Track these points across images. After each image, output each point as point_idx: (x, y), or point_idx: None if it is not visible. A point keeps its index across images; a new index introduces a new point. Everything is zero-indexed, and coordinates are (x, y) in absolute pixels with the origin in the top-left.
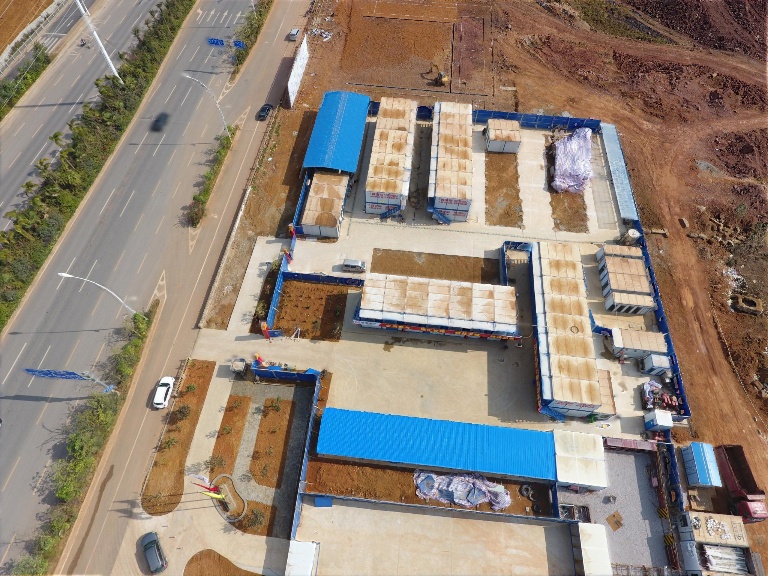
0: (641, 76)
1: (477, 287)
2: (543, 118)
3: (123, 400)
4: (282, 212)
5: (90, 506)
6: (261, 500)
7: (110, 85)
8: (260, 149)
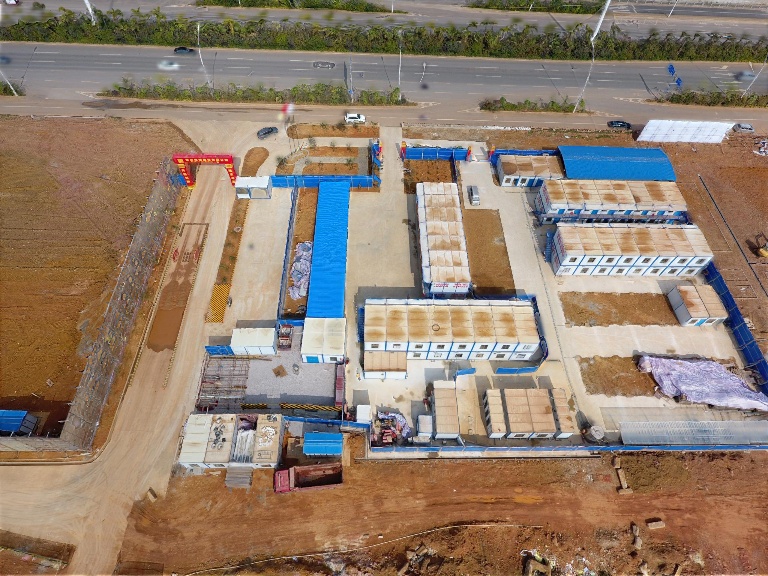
0: None
1: (462, 254)
2: (754, 347)
3: (349, 105)
4: None
5: (291, 107)
6: (295, 170)
7: (583, 32)
8: None
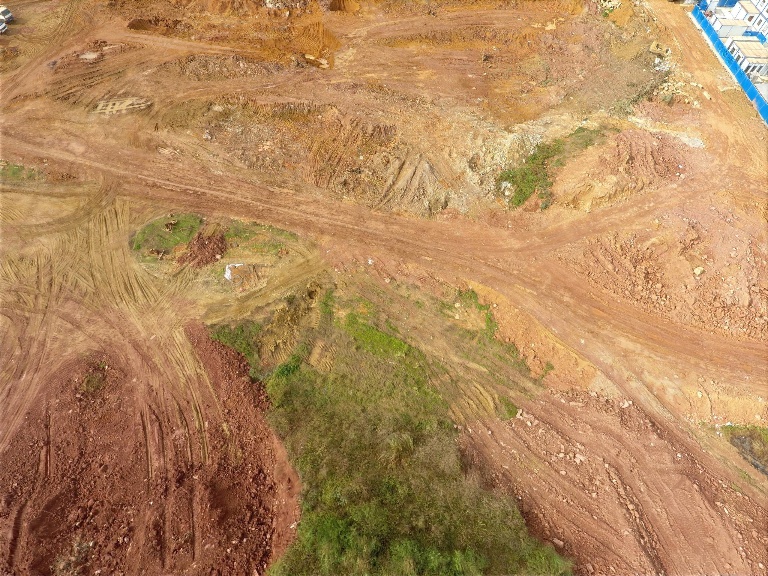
0: None
1: None
2: None
3: None
4: None
5: None
6: None
7: None
8: None
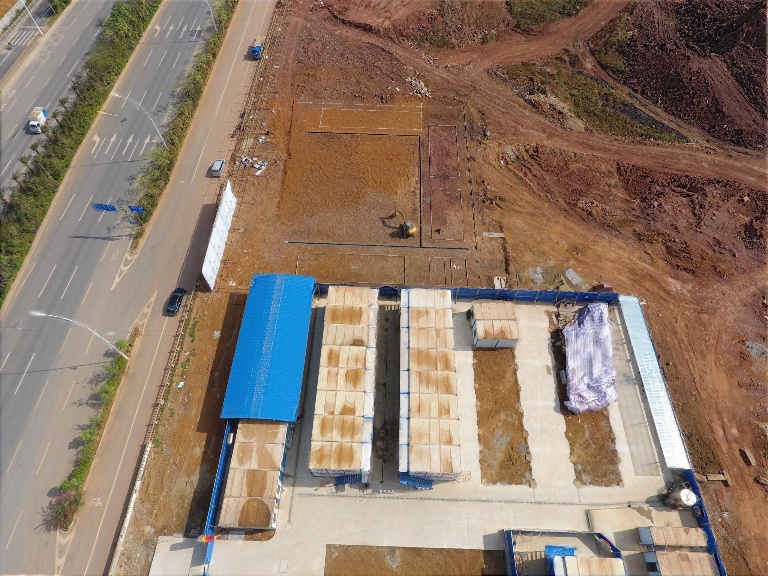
0: (656, 204)
1: None
2: (544, 293)
3: None
4: (195, 486)
5: None
6: None
7: None
8: (167, 367)
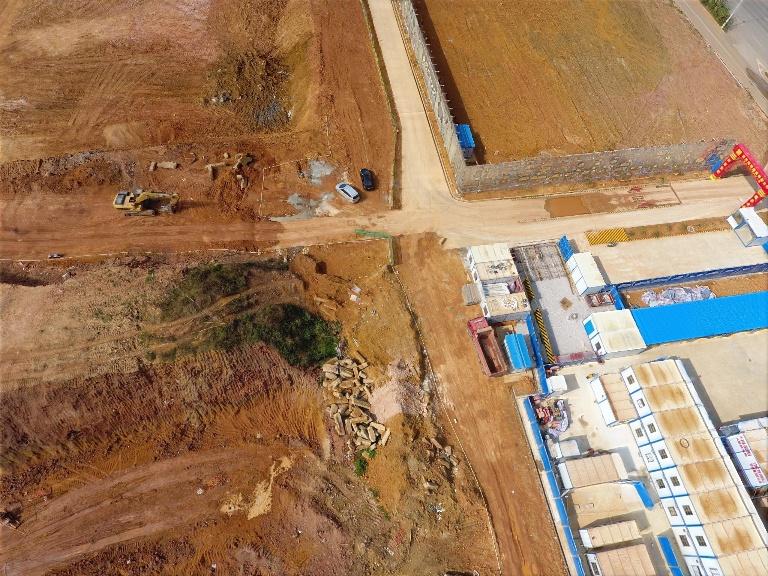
0: None
1: None
2: None
3: None
4: None
5: None
6: None
7: None
8: None
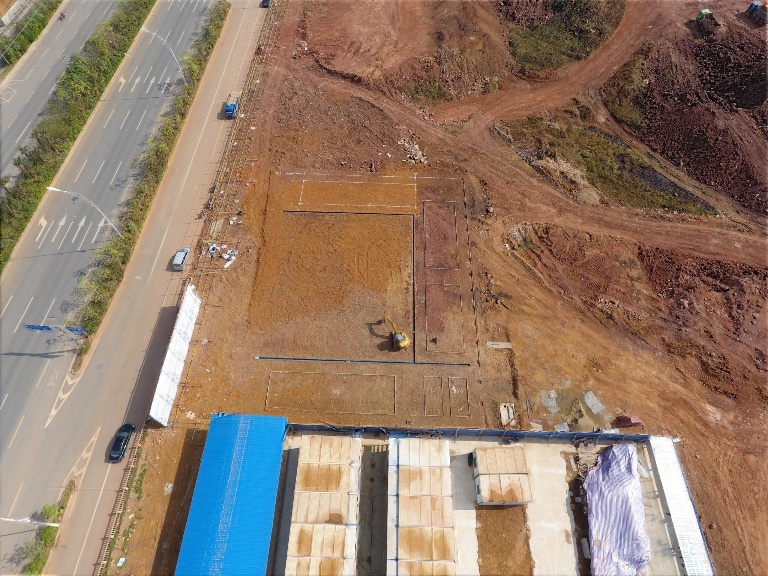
0: None
1: None
2: (561, 433)
3: None
4: None
5: None
6: None
7: None
8: (106, 536)
